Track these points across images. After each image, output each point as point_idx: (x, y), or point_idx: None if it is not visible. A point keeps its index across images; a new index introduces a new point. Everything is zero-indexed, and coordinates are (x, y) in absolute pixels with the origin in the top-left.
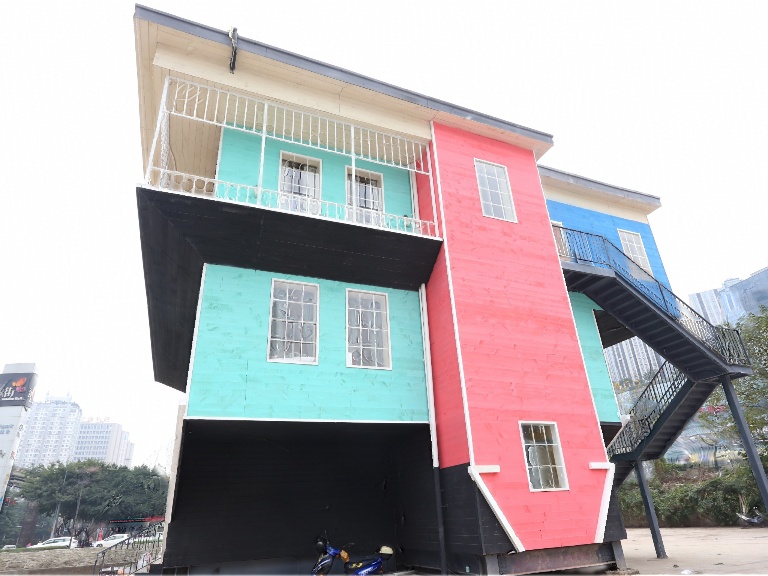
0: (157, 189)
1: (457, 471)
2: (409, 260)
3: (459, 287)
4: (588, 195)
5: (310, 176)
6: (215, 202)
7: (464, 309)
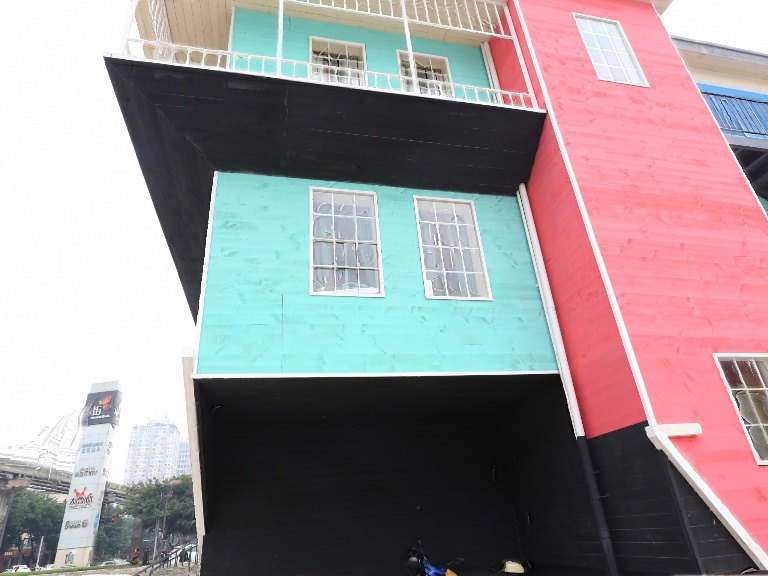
0: (133, 58)
1: (621, 438)
2: (499, 148)
3: (582, 168)
4: (728, 71)
5: (351, 64)
6: (216, 74)
7: (595, 197)
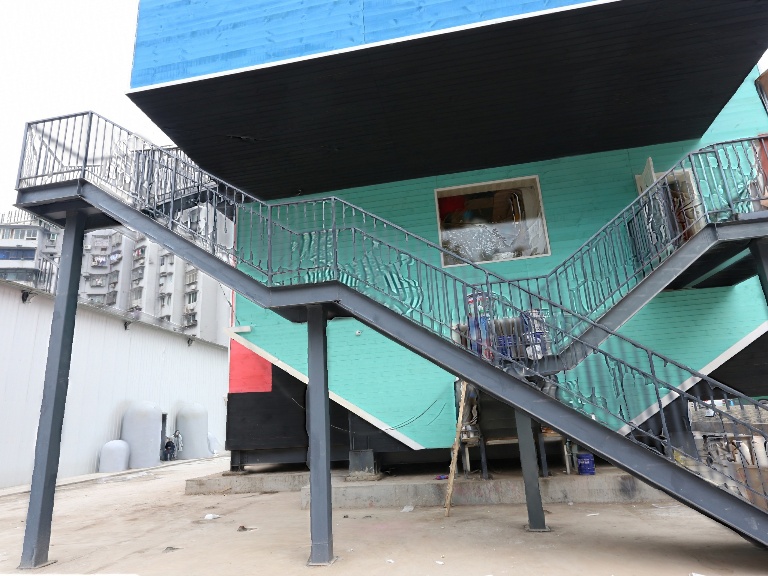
0: None
1: None
2: None
3: None
4: None
5: None
6: None
7: None
